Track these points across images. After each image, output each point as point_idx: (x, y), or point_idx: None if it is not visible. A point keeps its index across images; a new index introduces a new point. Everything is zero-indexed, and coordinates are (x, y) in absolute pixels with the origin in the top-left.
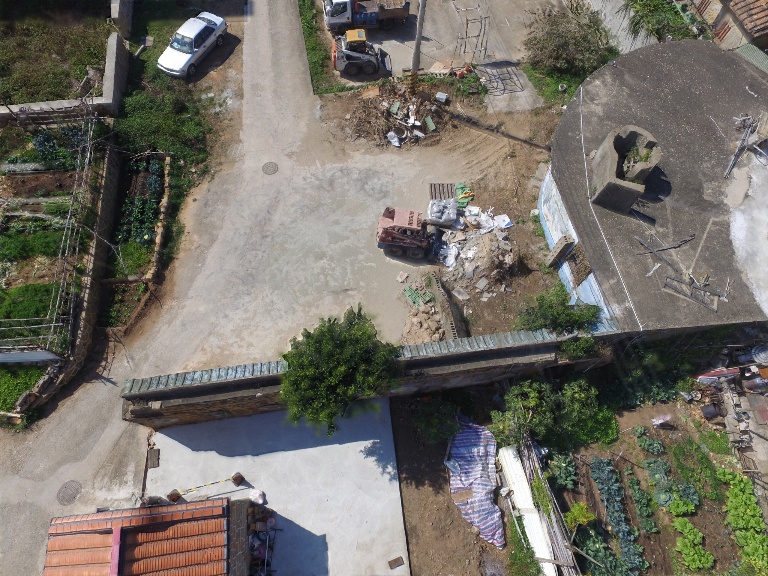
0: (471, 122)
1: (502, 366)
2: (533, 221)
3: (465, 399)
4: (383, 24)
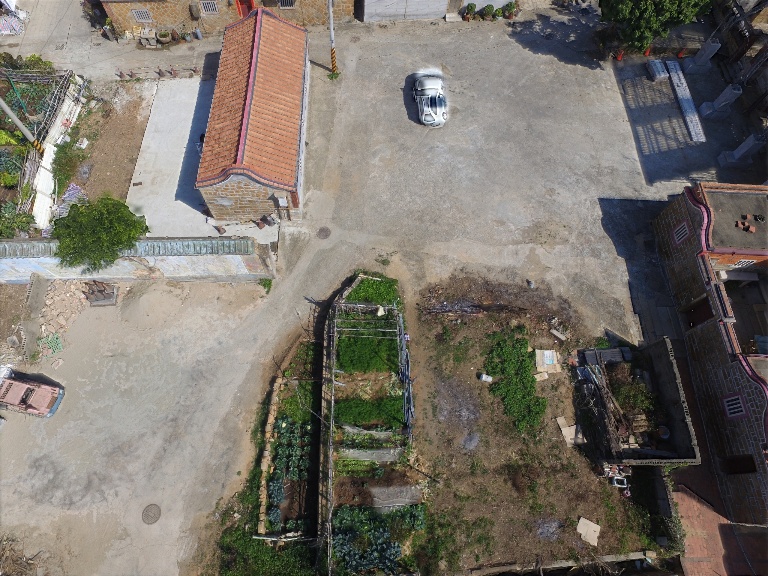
0: None
1: None
2: None
3: None
4: None
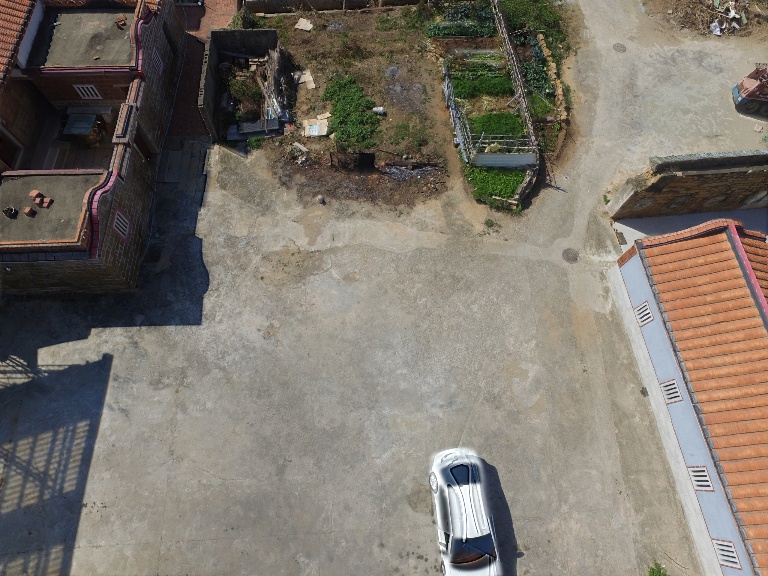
0: None
1: None
2: None
3: None
4: None
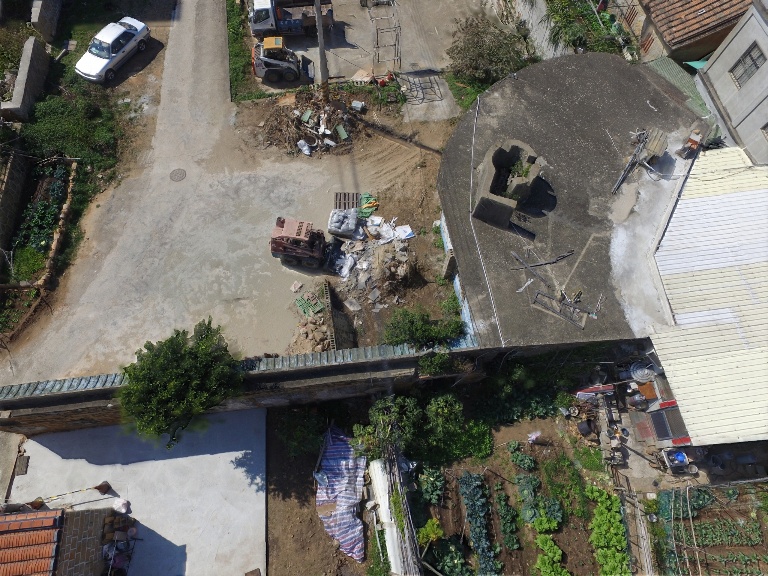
0: (385, 131)
1: (361, 380)
2: (434, 232)
3: (341, 411)
4: (309, 31)
